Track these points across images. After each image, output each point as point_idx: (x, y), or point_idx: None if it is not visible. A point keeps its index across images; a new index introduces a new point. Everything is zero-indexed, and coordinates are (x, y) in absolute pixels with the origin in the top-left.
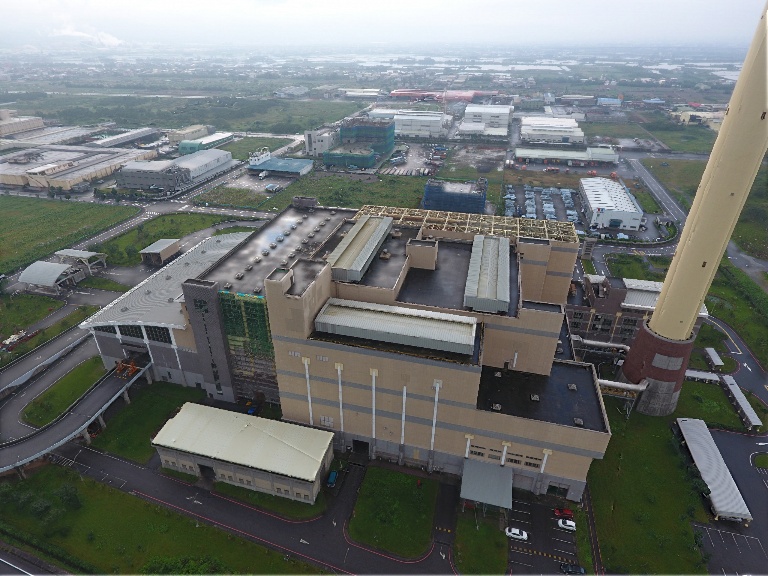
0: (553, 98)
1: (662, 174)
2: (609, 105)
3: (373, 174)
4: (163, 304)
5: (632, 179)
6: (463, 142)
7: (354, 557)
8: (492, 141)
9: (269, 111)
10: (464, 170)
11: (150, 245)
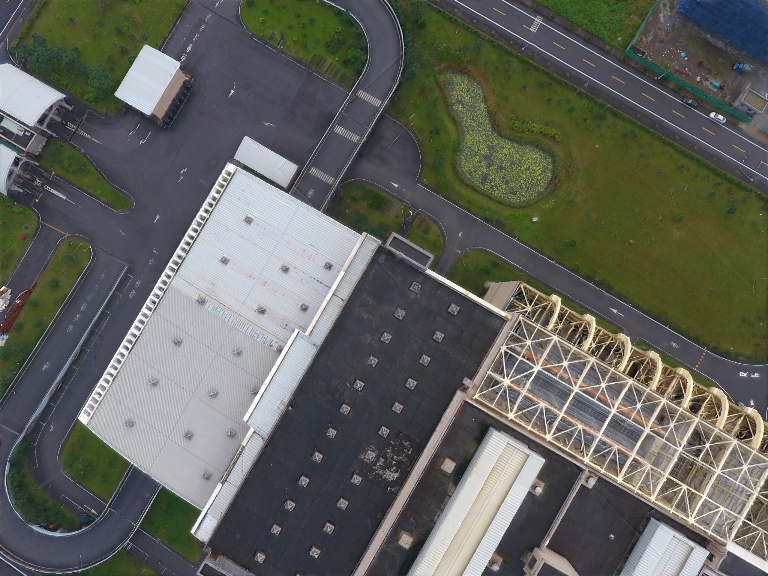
0: None
1: None
2: None
3: None
4: (179, 439)
5: None
6: None
7: None
8: None
9: None
10: None
11: (130, 70)
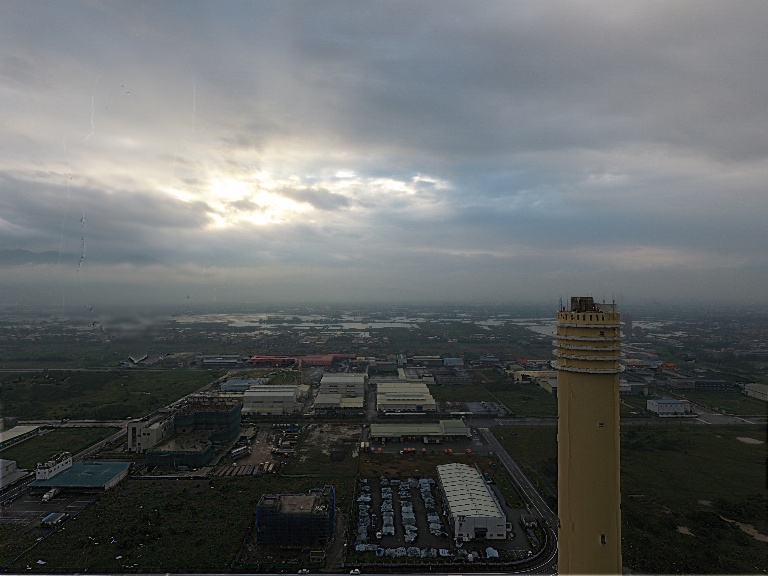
0: (405, 360)
1: (513, 447)
2: (454, 364)
3: (205, 477)
4: None
5: (487, 456)
6: (318, 418)
7: None
8: (348, 415)
9: (106, 387)
10: (315, 460)
11: None
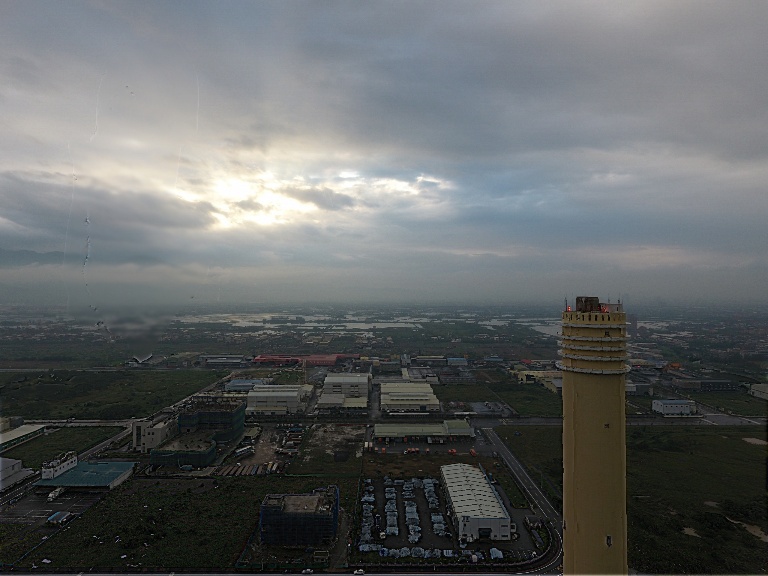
0: (409, 360)
1: (517, 447)
2: (458, 364)
3: (209, 477)
4: None
5: (491, 456)
6: (322, 418)
7: None
8: (352, 415)
9: (111, 387)
10: (319, 459)
11: None
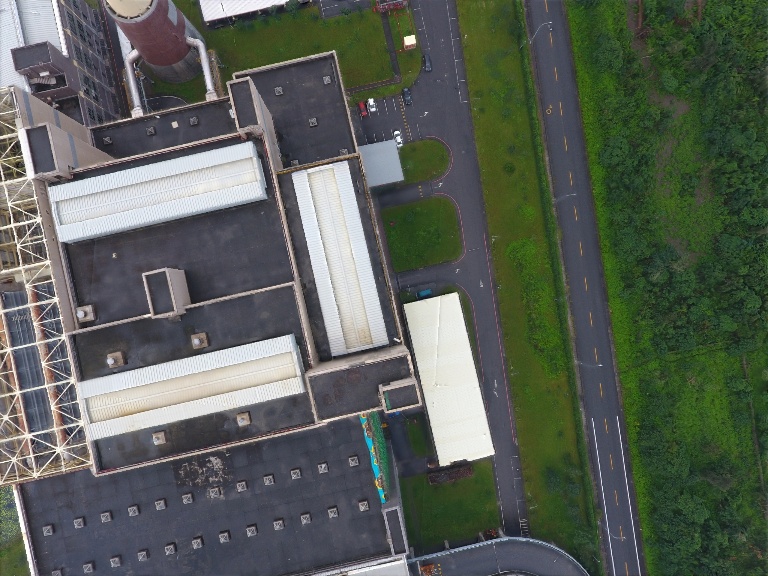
0: None
1: None
2: None
3: None
4: None
5: None
6: None
7: (473, 243)
8: None
9: None
10: None
11: None
